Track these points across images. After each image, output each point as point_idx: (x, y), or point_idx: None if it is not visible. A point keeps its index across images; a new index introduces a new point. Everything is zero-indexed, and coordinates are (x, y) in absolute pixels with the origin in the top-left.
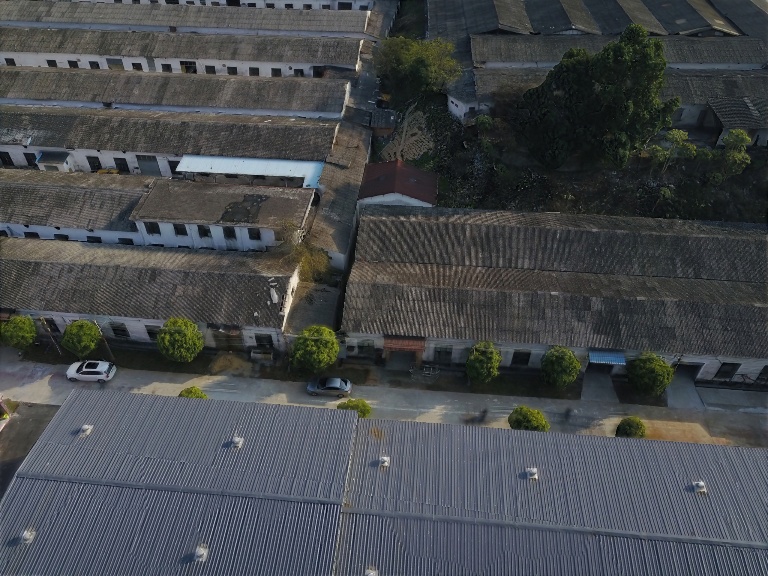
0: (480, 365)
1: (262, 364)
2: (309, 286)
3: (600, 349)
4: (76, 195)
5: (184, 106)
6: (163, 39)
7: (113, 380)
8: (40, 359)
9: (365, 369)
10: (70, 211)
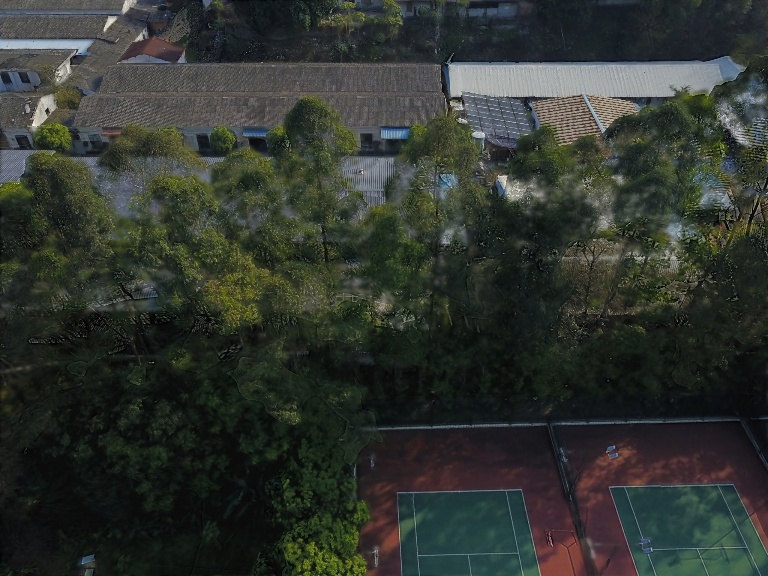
0: None
1: None
2: (64, 111)
3: (249, 128)
4: None
5: None
6: None
7: None
8: None
9: None
10: None
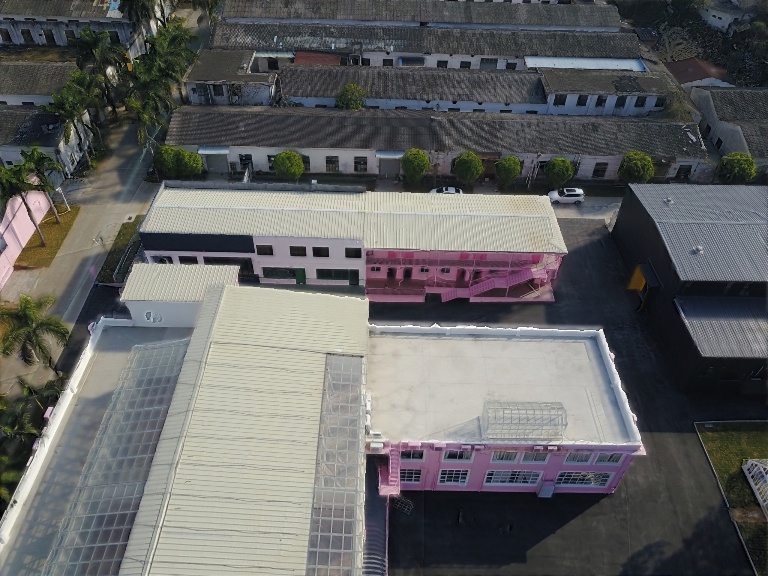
0: None
1: None
2: None
3: None
4: (485, 79)
5: (491, 24)
6: None
7: (585, 202)
8: (515, 193)
9: None
10: (487, 90)
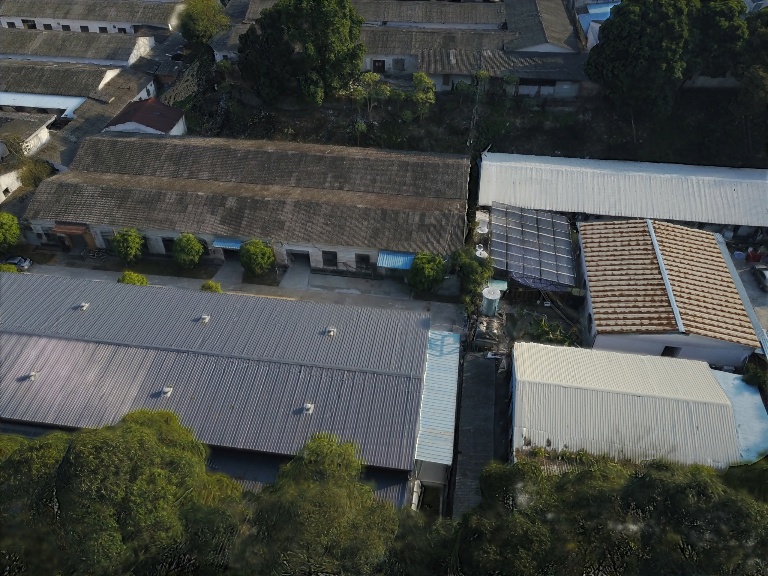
0: (117, 244)
1: None
2: (28, 190)
3: (222, 236)
4: None
5: None
6: (10, 0)
7: None
8: None
9: (52, 254)
10: None
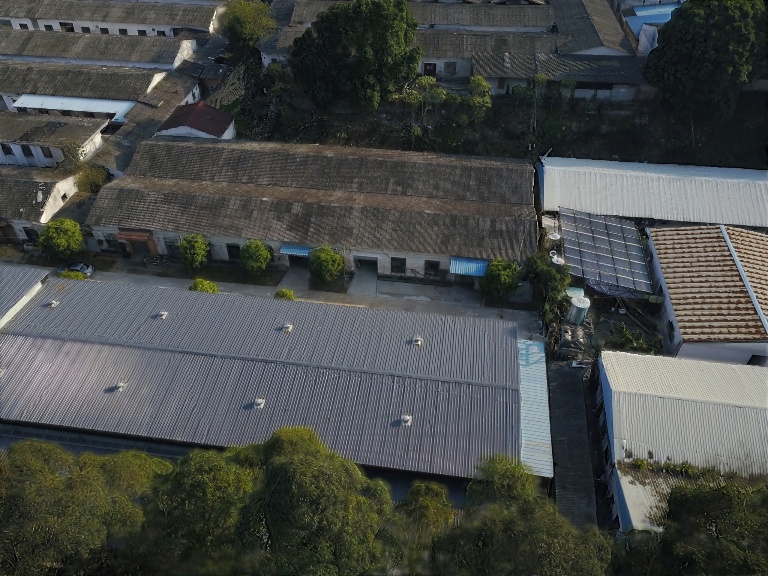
0: (184, 251)
1: (32, 254)
2: (85, 195)
3: (289, 243)
4: None
5: (41, 57)
6: (47, 3)
7: None
8: None
9: (113, 260)
10: None
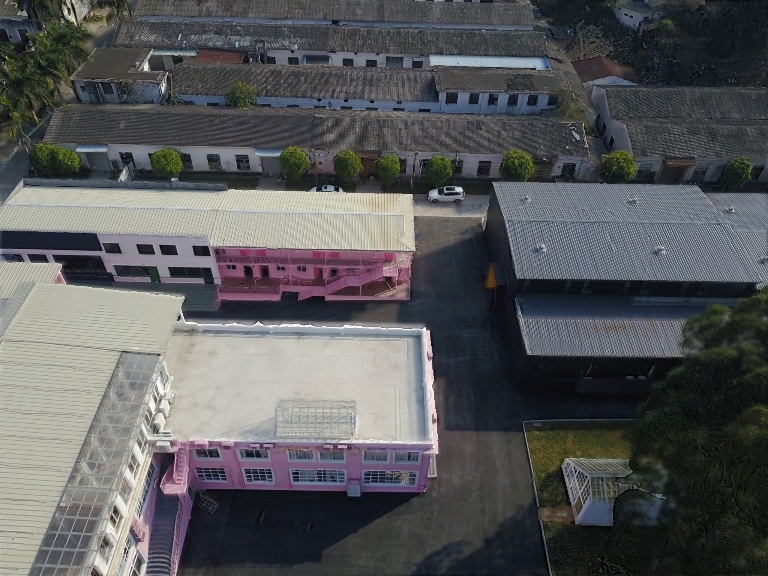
0: (742, 171)
1: None
2: None
3: None
4: (379, 77)
5: (403, 22)
6: None
7: (465, 200)
8: (397, 191)
9: None
10: (379, 89)
